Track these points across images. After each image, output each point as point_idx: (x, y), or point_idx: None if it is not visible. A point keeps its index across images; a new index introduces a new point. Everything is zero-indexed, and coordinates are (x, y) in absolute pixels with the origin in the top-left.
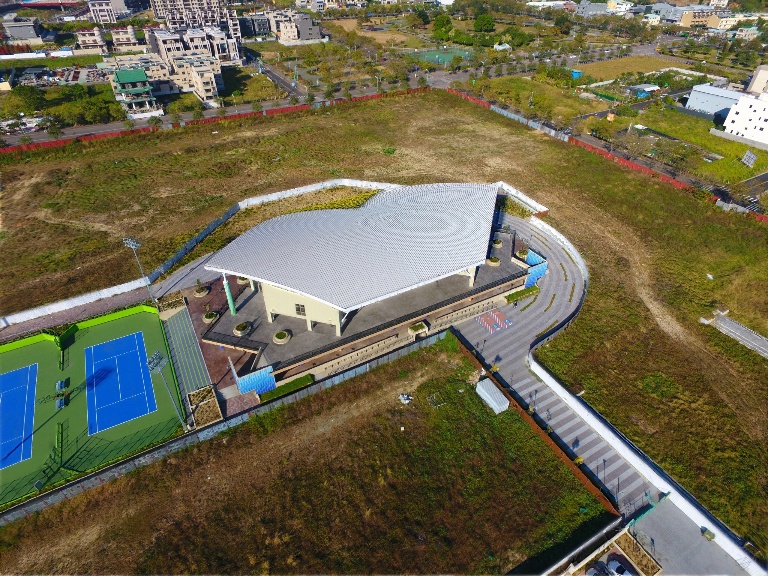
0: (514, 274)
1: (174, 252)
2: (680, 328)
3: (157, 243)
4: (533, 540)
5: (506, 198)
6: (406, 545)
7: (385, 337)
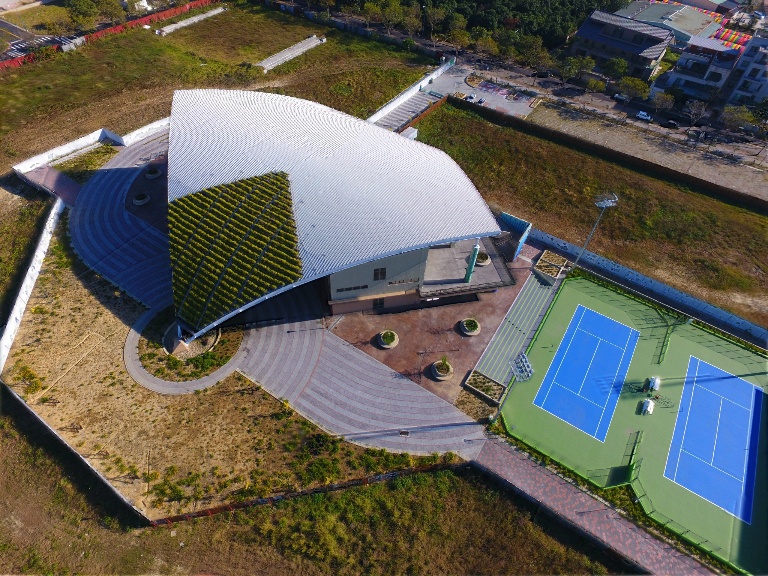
0: None
1: (381, 505)
2: (276, 81)
3: None
4: None
5: (63, 165)
6: None
7: None
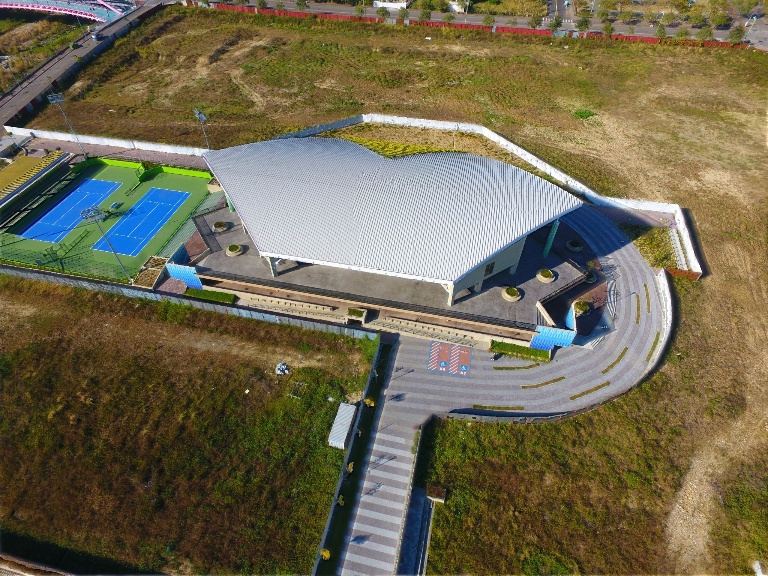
0: (517, 321)
1: None
2: (701, 545)
3: (271, 126)
4: (214, 573)
5: (660, 230)
6: (134, 478)
7: (324, 303)
